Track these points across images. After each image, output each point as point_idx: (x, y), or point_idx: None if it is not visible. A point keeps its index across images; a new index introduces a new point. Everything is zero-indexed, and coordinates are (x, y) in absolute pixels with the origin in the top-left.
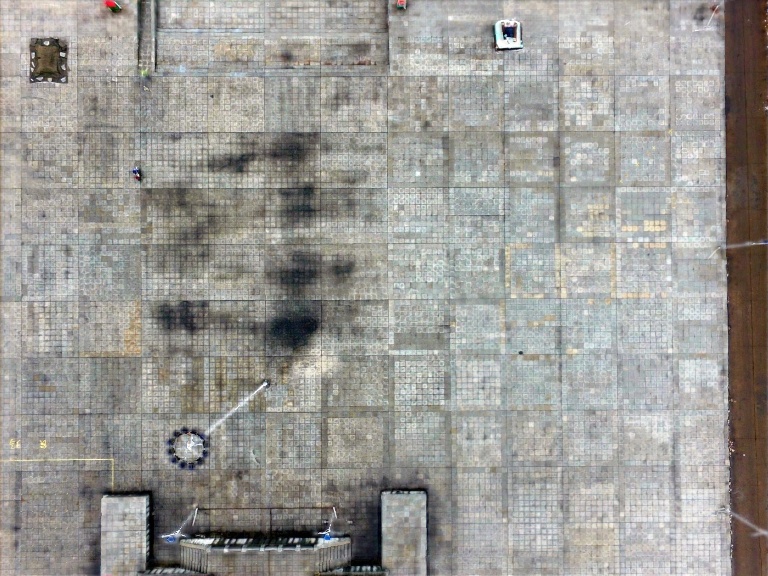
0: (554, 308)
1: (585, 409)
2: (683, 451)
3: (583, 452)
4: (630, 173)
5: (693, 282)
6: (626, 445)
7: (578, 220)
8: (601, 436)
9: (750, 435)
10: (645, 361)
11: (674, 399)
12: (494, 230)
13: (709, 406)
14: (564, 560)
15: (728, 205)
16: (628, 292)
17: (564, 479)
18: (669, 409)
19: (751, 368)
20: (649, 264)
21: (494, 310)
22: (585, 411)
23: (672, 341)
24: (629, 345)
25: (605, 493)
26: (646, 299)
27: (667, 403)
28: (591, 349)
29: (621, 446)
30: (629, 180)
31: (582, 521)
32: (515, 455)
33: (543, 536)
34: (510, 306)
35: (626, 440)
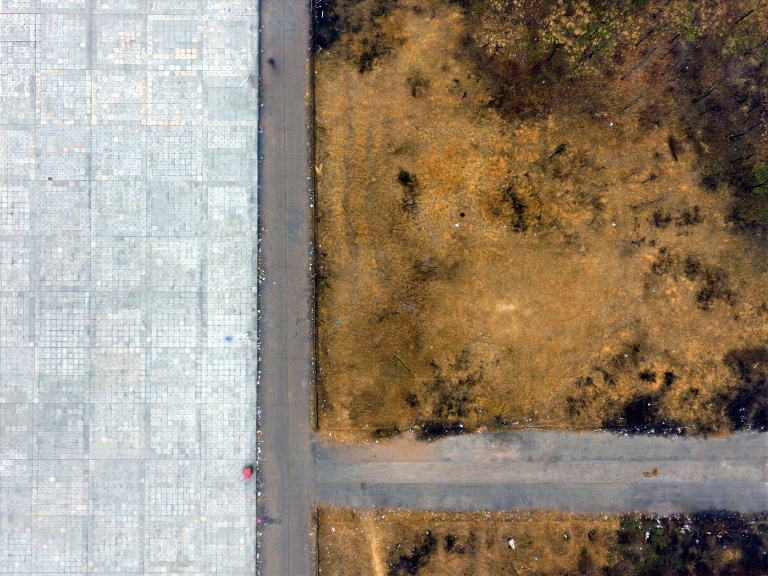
0: (84, 135)
1: (114, 235)
2: (210, 278)
3: (111, 278)
4: (162, 1)
5: (223, 110)
6: (154, 271)
7: (109, 47)
8: (129, 262)
9: (281, 264)
10: (174, 188)
11: (203, 226)
12: (25, 56)
13: (237, 233)
14: (90, 384)
15: (263, 36)
16: (158, 120)
17: (91, 304)
18: (197, 236)
19: (283, 197)
20: (180, 92)
21: (24, 136)
22: (113, 237)
23: (202, 169)
24: (159, 172)
25: (132, 319)
26: (176, 127)
27: (195, 230)
28: (120, 176)
29: (149, 272)
30: (161, 8)
31: (108, 346)
32: (43, 280)
33: (69, 360)
34: (40, 132)
35: (154, 266)
